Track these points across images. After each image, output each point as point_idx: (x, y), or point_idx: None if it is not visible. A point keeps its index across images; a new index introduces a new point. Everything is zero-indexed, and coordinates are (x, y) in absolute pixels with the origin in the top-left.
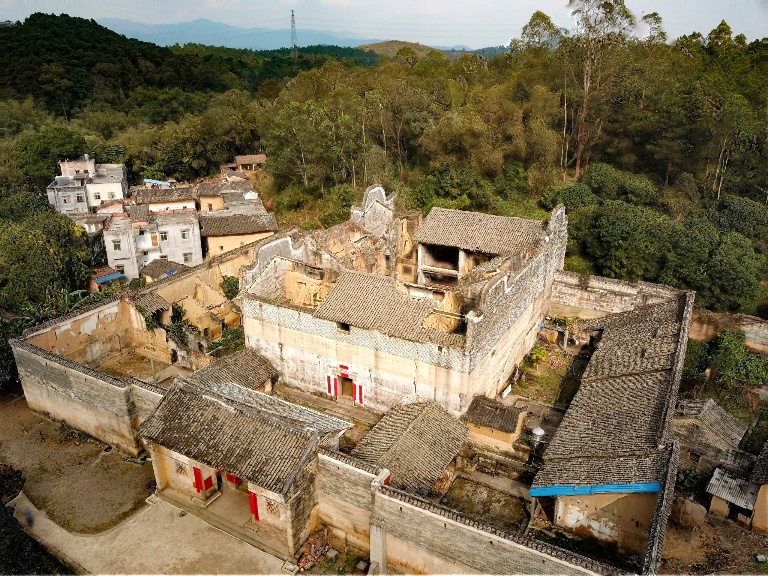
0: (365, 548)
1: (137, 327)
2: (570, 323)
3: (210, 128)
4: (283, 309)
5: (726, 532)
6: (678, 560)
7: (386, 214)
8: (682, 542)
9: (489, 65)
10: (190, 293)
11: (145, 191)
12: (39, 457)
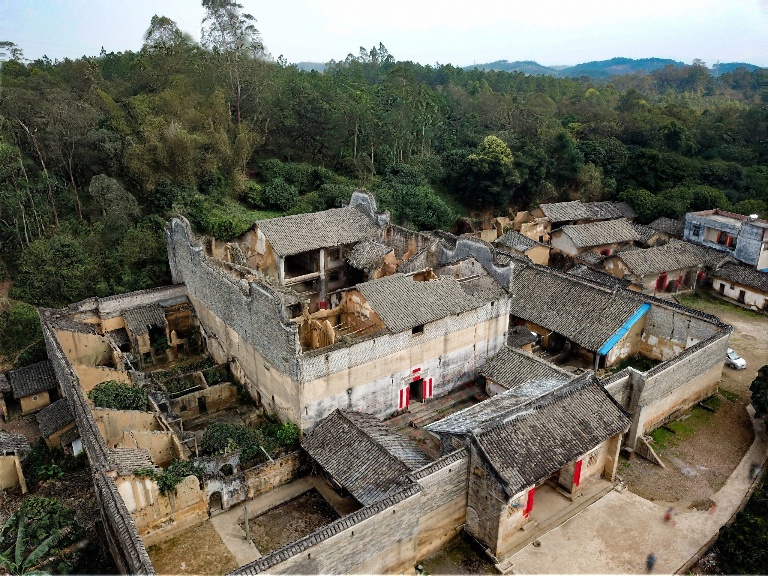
0: None
1: (133, 508)
2: None
3: None
4: (355, 346)
5: None
6: None
7: None
8: None
9: (99, 73)
10: None
11: None
12: None
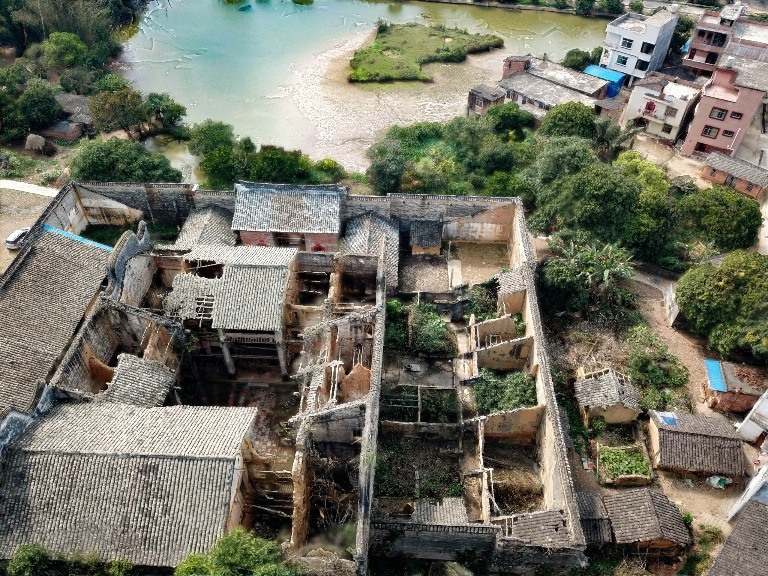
0: None
1: None
2: None
3: None
4: None
5: None
6: None
7: None
8: None
9: None
10: None
11: None
12: None
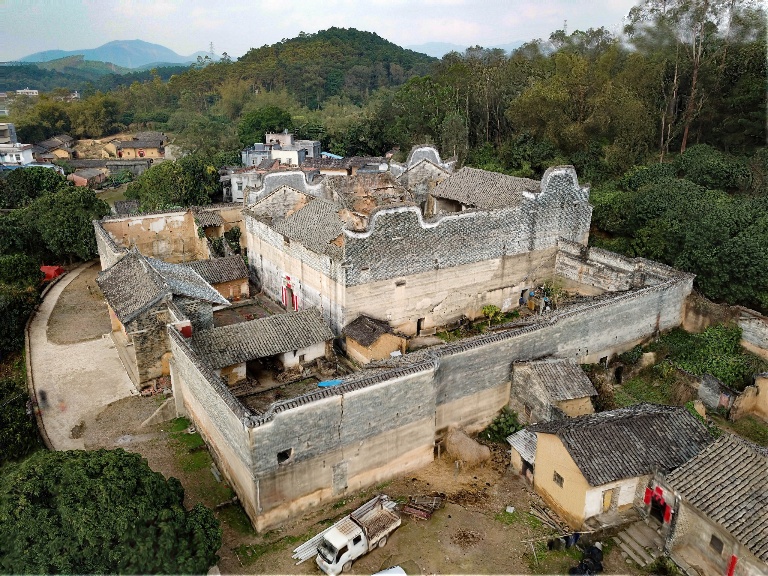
0: None
1: (196, 236)
2: (553, 292)
3: (387, 112)
4: (261, 223)
5: (506, 483)
6: (427, 484)
7: (441, 177)
8: (449, 474)
9: None
10: None
11: (310, 159)
12: (79, 301)
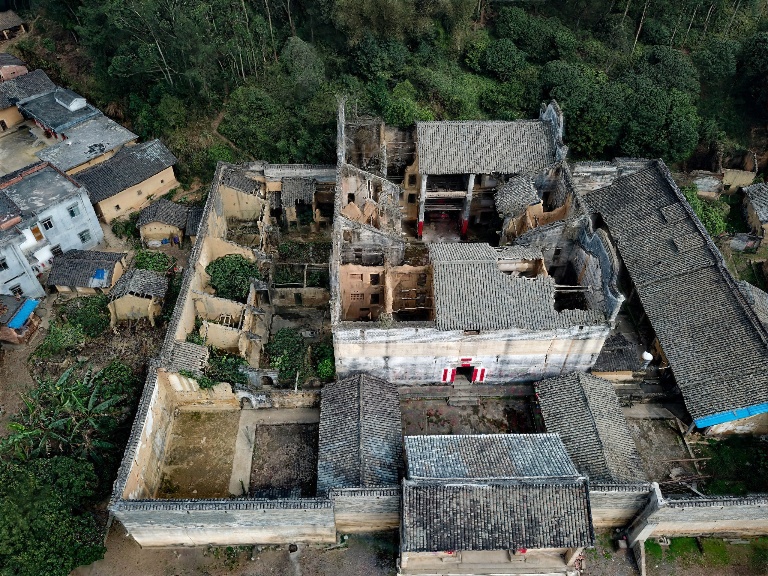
0: (608, 526)
1: (181, 389)
2: None
3: None
4: (395, 329)
5: None
6: None
7: None
8: None
9: None
10: (191, 312)
11: None
12: None
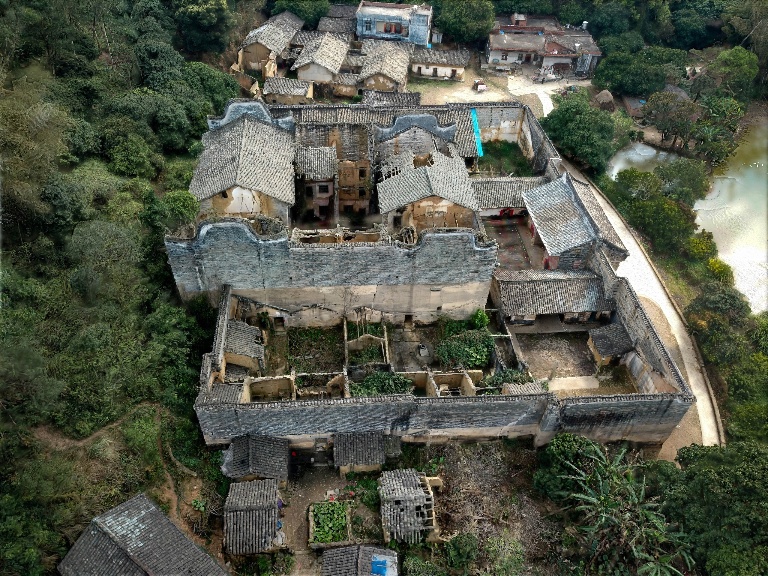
0: None
1: None
2: None
3: None
4: None
5: None
6: None
7: None
8: None
9: None
10: None
11: None
12: None
